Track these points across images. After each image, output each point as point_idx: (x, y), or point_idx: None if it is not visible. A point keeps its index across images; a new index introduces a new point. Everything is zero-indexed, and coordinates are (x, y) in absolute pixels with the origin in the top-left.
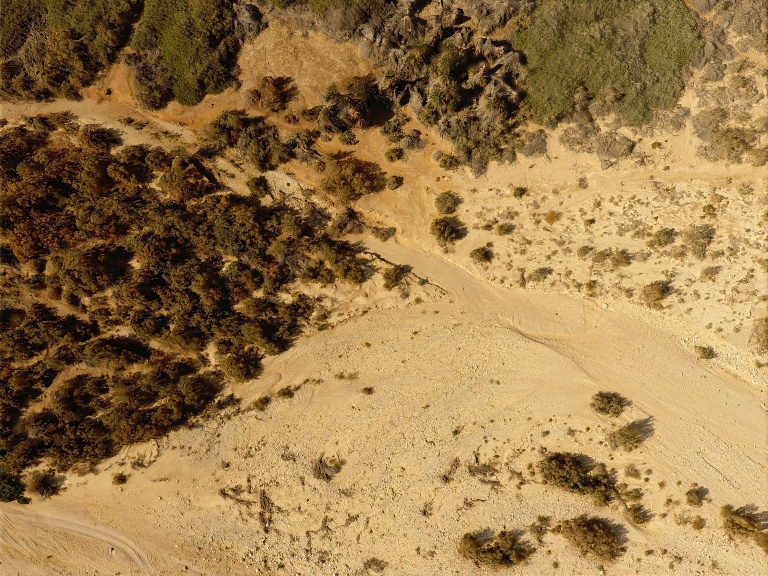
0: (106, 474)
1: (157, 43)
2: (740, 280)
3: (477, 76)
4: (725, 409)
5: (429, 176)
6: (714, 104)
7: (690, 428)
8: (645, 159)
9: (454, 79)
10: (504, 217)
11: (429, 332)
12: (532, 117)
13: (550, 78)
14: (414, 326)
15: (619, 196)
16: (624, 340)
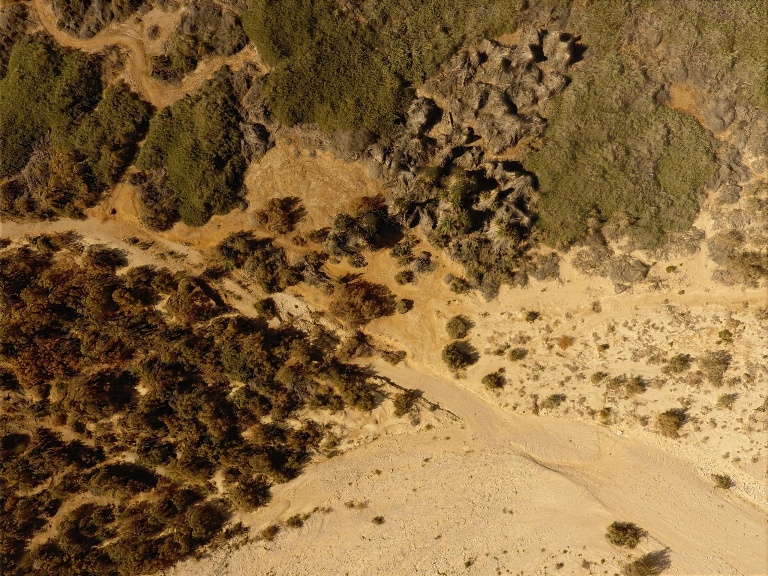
0: None
1: (162, 163)
2: (757, 408)
3: (488, 202)
4: (743, 540)
5: (440, 299)
6: (730, 226)
7: (707, 560)
8: (660, 284)
9: (465, 207)
10: (516, 342)
11: (440, 459)
12: (544, 240)
13: (563, 202)
14: (425, 453)
15: (633, 321)
16: (639, 468)
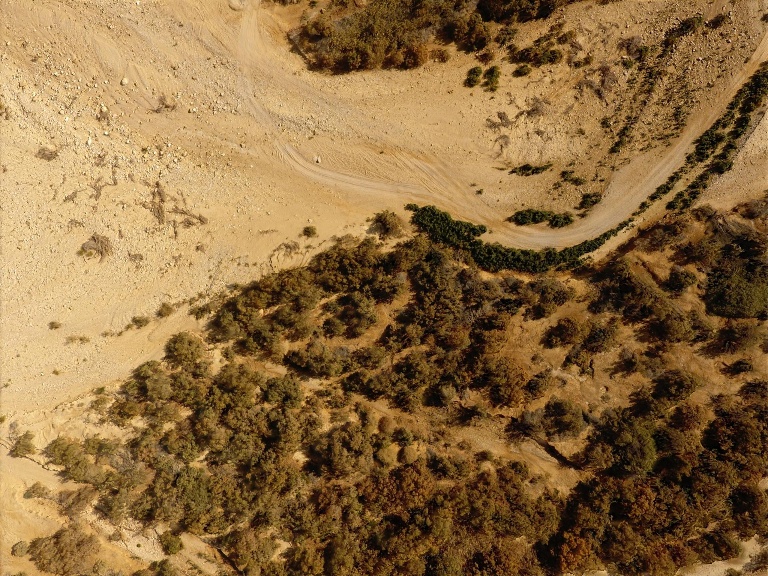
0: (325, 236)
1: None
2: None
3: None
4: None
5: None
6: None
7: None
8: None
9: None
10: None
11: None
12: None
13: None
14: (8, 393)
15: None
16: None
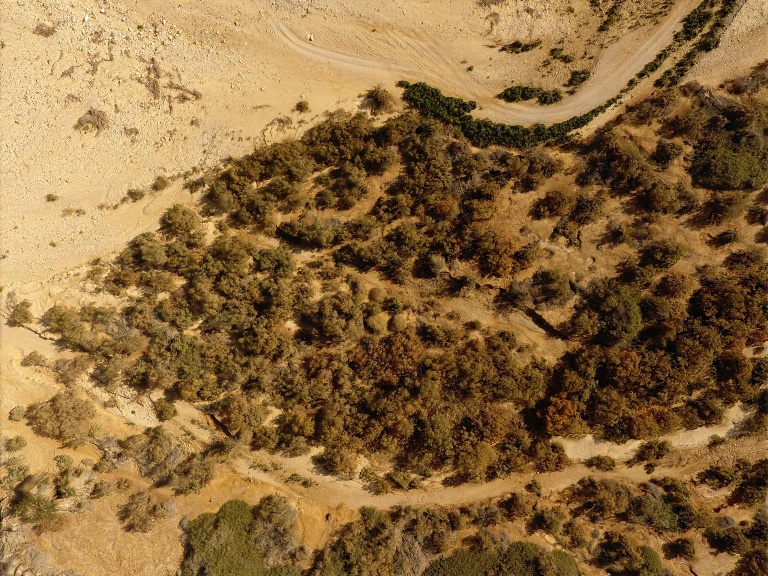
0: (317, 112)
1: (270, 573)
2: None
3: None
4: None
5: None
6: None
7: None
8: None
9: None
10: None
11: None
12: None
13: None
14: (6, 264)
15: None
16: None
